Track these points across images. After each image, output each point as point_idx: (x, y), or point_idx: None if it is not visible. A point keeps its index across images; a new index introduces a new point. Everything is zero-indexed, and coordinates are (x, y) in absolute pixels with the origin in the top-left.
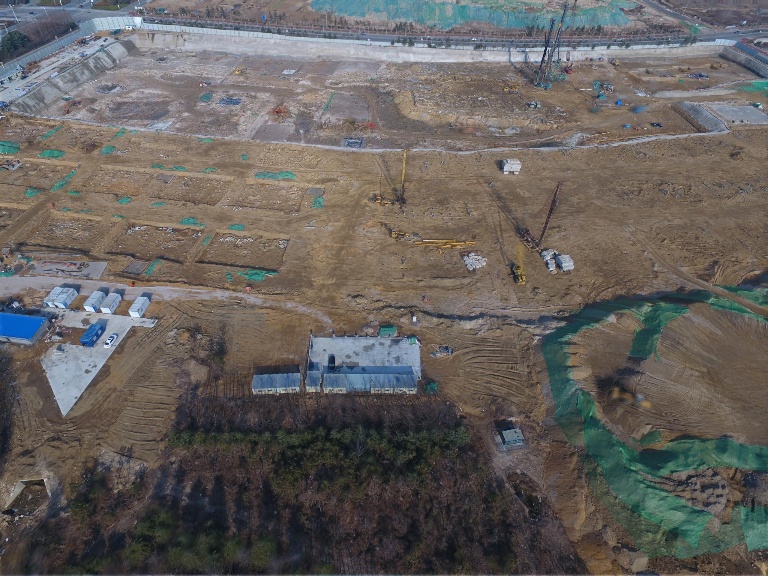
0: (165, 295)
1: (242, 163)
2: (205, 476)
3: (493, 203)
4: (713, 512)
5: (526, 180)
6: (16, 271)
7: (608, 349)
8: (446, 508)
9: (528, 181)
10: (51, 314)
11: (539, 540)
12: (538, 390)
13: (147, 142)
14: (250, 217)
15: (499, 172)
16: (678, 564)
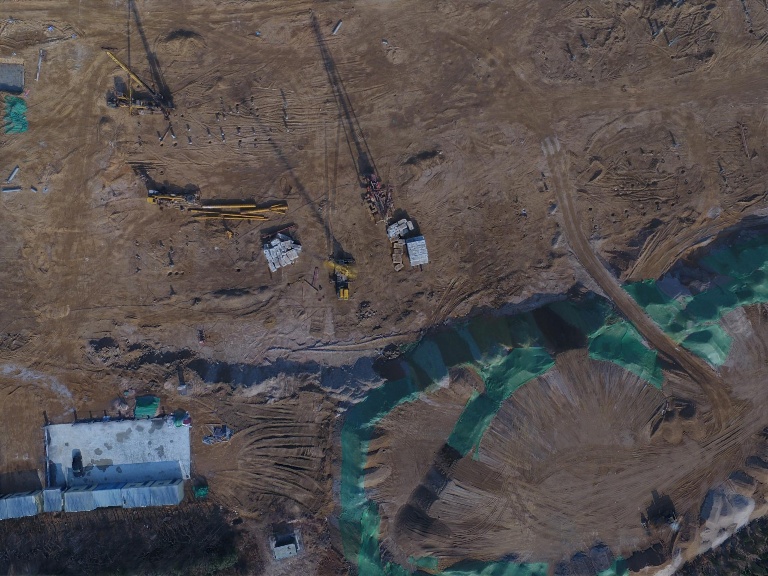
0: None
1: None
2: None
3: (333, 90)
4: None
5: (407, 8)
6: None
7: (423, 435)
8: None
9: (410, 11)
10: None
11: None
12: (327, 486)
13: None
14: None
15: None
16: None
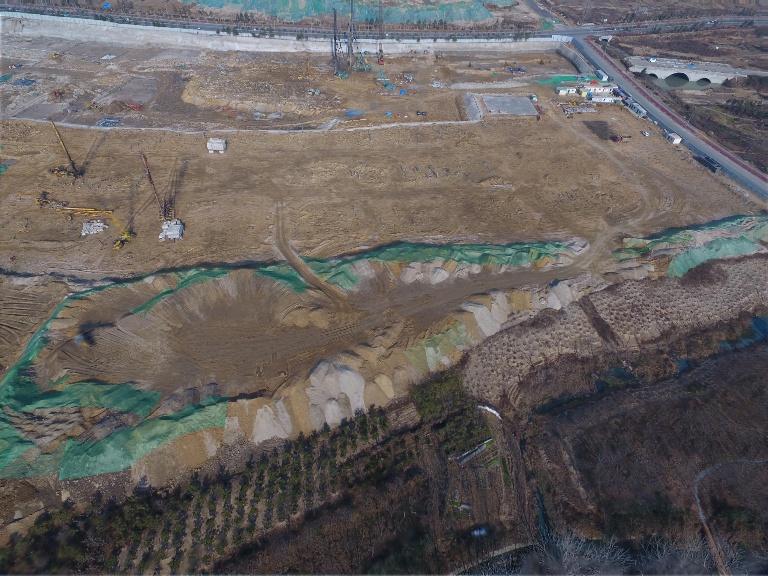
0: None
1: None
2: None
3: (170, 178)
4: (39, 443)
5: (225, 159)
6: None
7: (115, 305)
8: None
9: (226, 160)
10: None
11: None
12: (25, 339)
13: None
14: None
15: (206, 151)
16: None
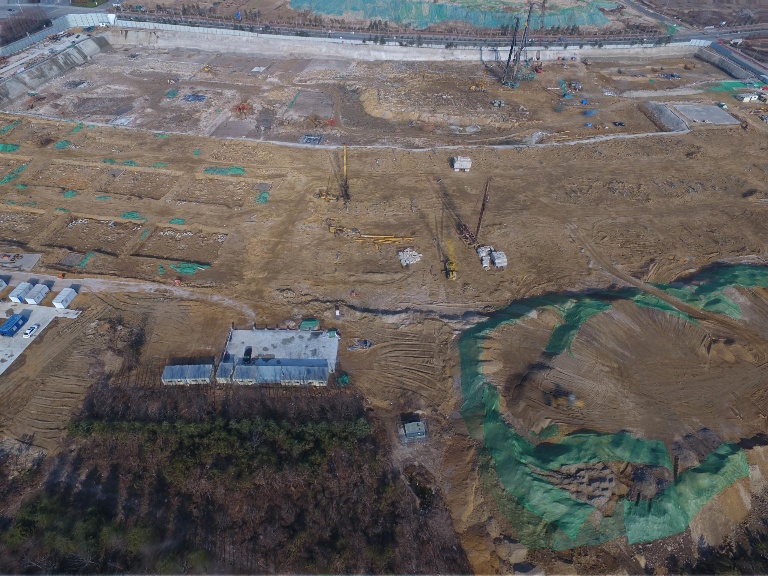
0: (93, 287)
1: (194, 158)
2: (102, 464)
3: (439, 200)
4: (596, 505)
5: (476, 177)
6: None
7: (524, 344)
8: (337, 498)
9: (478, 178)
10: None
11: (425, 531)
12: (449, 384)
13: (102, 137)
14: (192, 211)
15: (450, 169)
16: (554, 556)
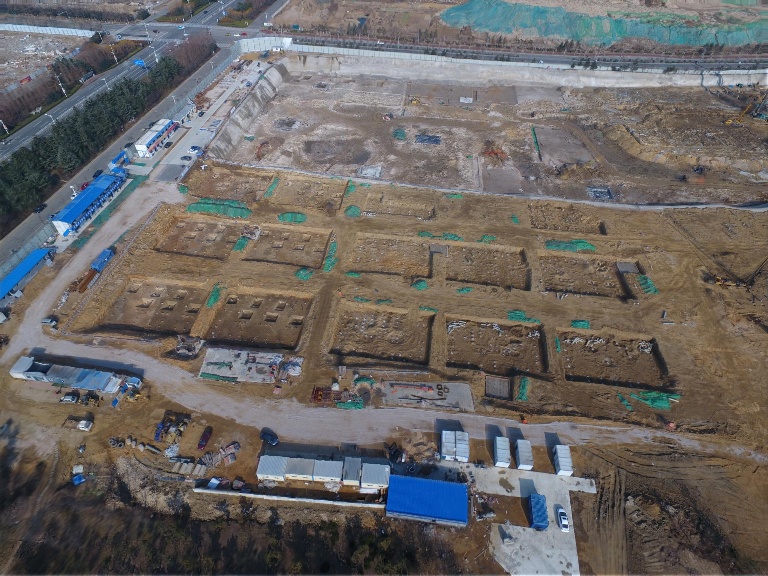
0: (574, 436)
1: (518, 228)
2: None
3: None
4: None
5: None
6: (365, 399)
7: None
8: None
9: None
10: (454, 472)
11: None
12: None
13: (390, 200)
14: (585, 308)
15: None
16: None
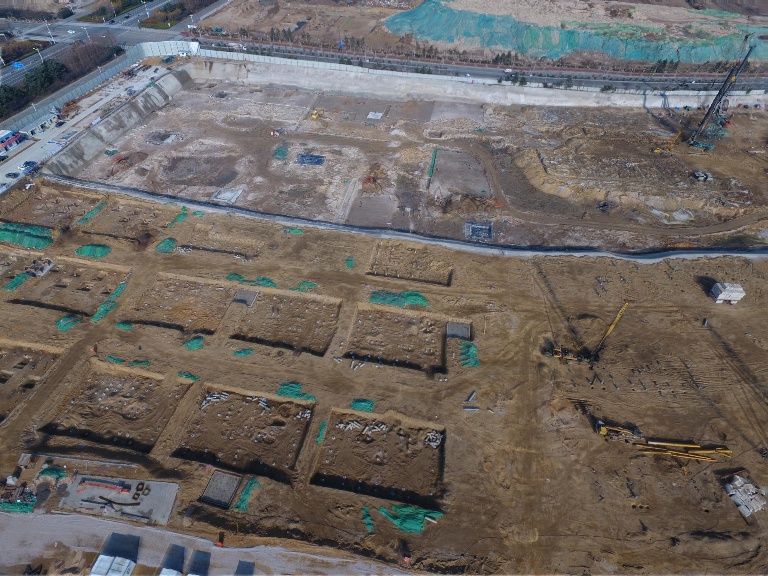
0: (274, 569)
1: (348, 274)
2: None
3: (723, 362)
4: None
5: (752, 316)
6: (39, 500)
7: None
8: None
9: (756, 318)
10: None
11: None
12: None
13: (217, 232)
14: (378, 383)
15: (708, 299)
16: None
